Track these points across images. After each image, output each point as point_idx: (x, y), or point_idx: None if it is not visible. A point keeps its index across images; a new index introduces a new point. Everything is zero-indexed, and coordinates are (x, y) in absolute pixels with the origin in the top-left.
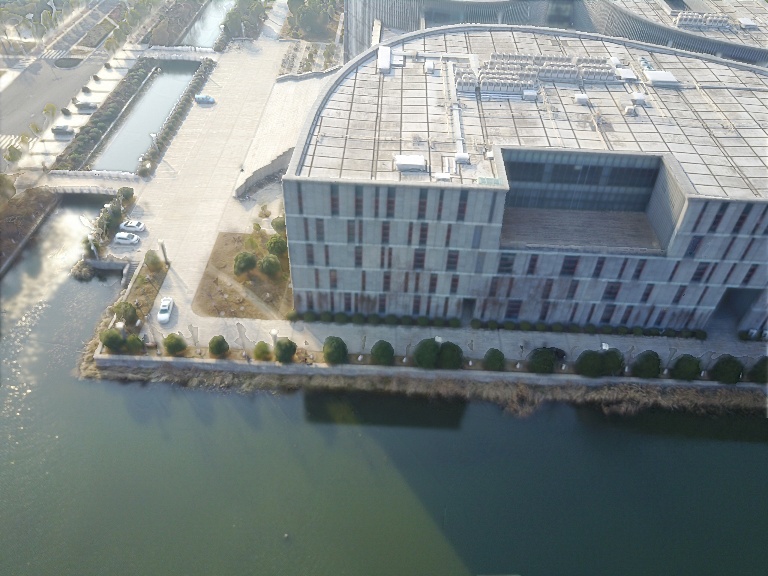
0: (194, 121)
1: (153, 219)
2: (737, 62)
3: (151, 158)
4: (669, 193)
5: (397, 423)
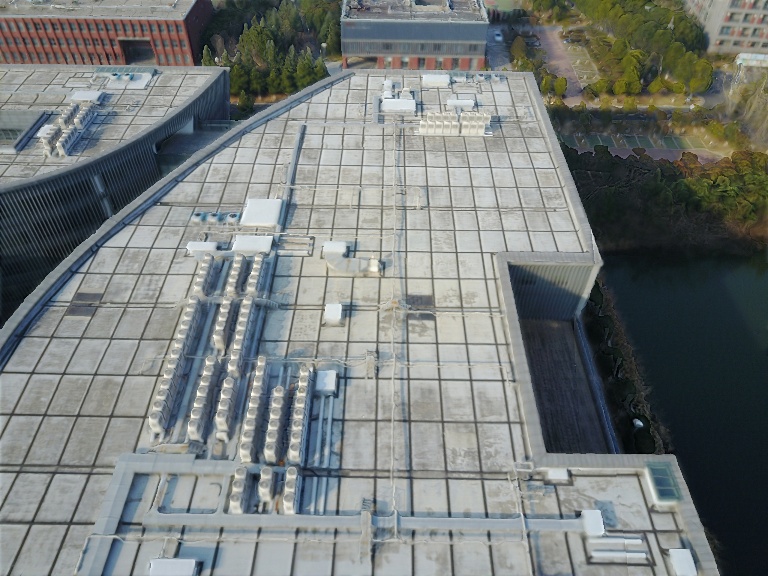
0: None
1: None
2: (225, 136)
3: None
4: (548, 280)
5: None
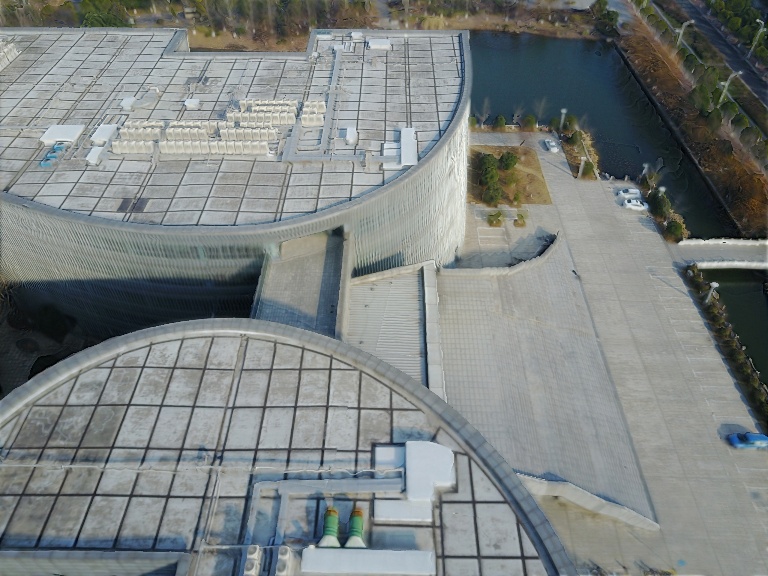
0: (717, 381)
1: (625, 216)
2: None
3: (701, 289)
4: None
5: None
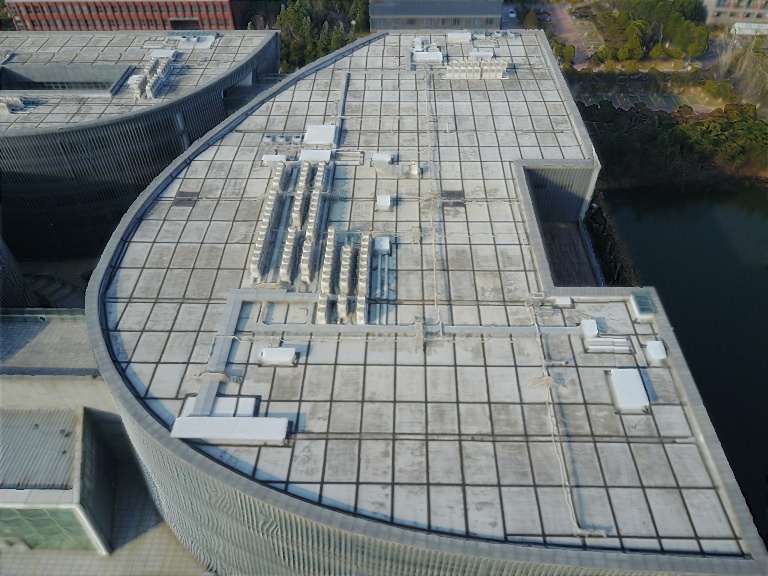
0: None
1: None
2: (283, 81)
3: None
4: (556, 183)
5: (767, 525)
